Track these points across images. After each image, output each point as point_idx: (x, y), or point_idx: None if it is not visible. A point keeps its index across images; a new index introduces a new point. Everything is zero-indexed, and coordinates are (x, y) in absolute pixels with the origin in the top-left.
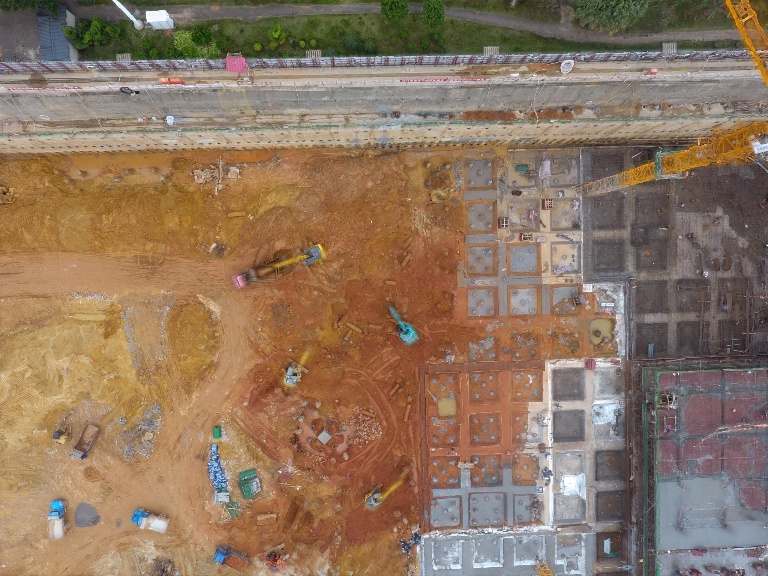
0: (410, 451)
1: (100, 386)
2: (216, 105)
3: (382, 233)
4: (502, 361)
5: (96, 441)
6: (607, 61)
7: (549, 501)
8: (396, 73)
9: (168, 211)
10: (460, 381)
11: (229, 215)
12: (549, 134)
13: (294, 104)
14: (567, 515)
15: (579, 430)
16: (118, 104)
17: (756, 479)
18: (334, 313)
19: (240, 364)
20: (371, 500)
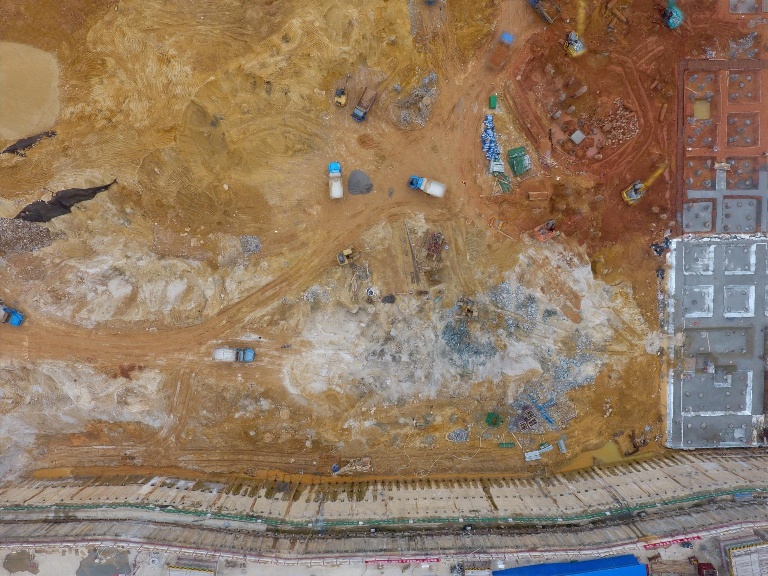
0: (664, 152)
1: (377, 51)
2: None
3: None
4: (763, 59)
5: (371, 108)
6: None
7: None
8: None
9: None
10: (720, 78)
11: None
12: None
13: None
14: None
15: None
16: None
17: None
18: None
19: (517, 34)
20: (632, 192)
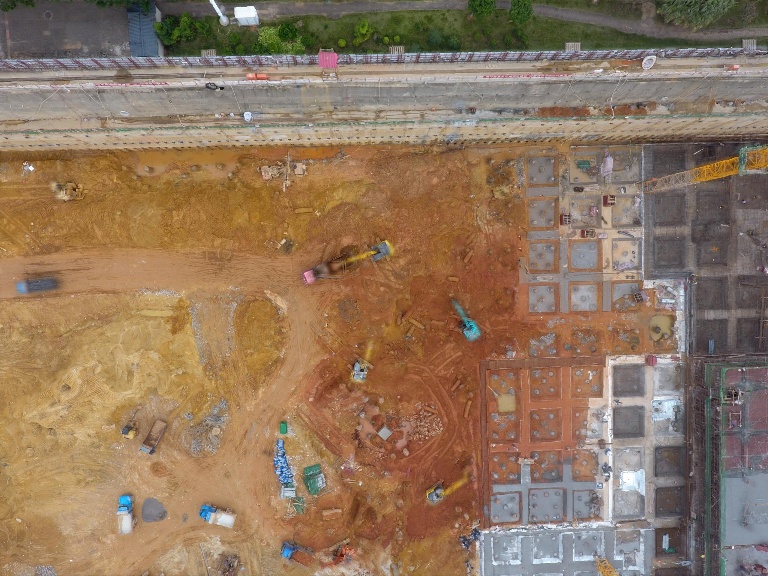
0: (470, 447)
1: (167, 382)
2: (297, 101)
3: (447, 229)
4: (563, 357)
5: (163, 436)
6: (688, 57)
7: (608, 497)
8: (479, 69)
9: (238, 207)
10: (521, 377)
11: (296, 211)
12: (617, 130)
13: (374, 100)
14: (626, 511)
15: (638, 426)
16: (201, 100)
17: None
18: (397, 309)
19: (306, 360)
20: (433, 496)
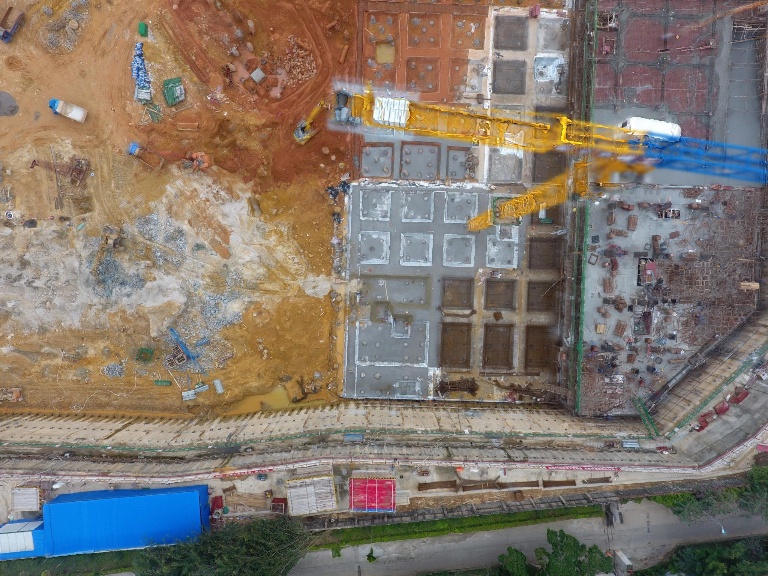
0: None
1: None
2: None
3: None
4: (444, 4)
5: (21, 30)
6: None
7: (484, 156)
8: None
9: None
10: (399, 21)
11: None
12: None
13: None
14: (503, 176)
15: (520, 85)
16: None
17: (697, 114)
18: None
19: None
20: (299, 130)
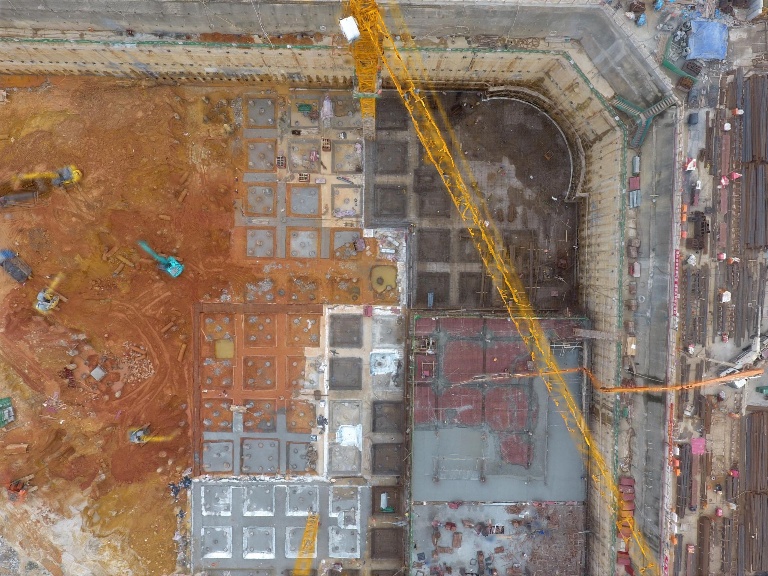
0: (183, 392)
1: None
2: None
3: (150, 164)
4: (279, 304)
5: None
6: None
7: (323, 450)
8: None
9: None
10: (235, 322)
11: None
12: (309, 67)
13: (14, 13)
14: (344, 466)
15: (358, 379)
16: None
17: (518, 432)
18: (103, 244)
19: None
20: (134, 438)
